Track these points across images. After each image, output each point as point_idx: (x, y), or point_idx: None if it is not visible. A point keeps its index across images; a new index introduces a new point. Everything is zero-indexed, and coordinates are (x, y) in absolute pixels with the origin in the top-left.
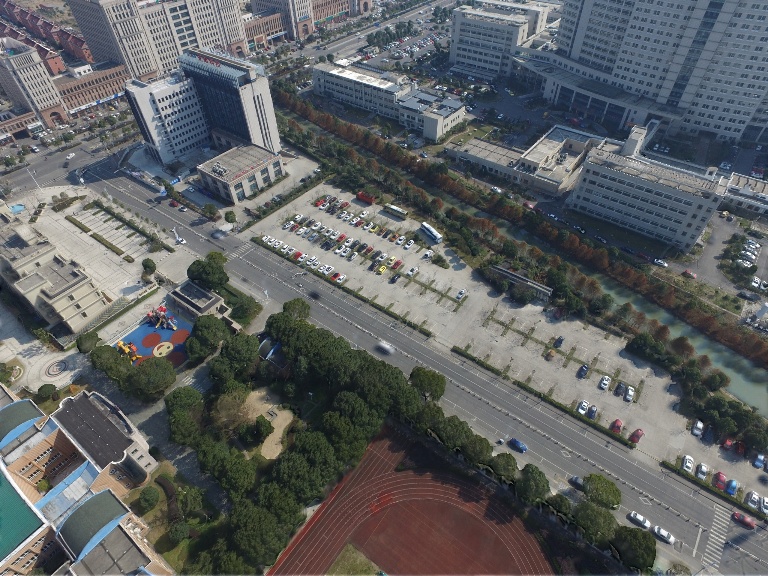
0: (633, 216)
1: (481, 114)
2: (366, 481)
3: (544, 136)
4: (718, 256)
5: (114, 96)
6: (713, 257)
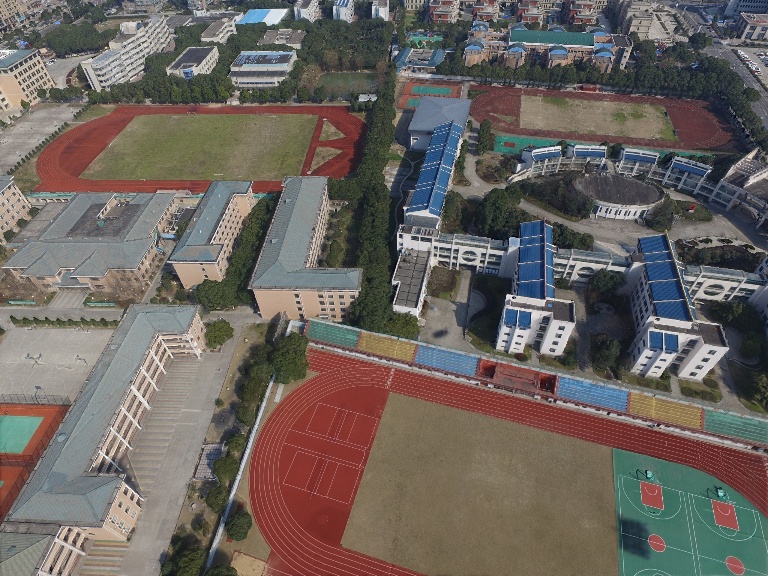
0: None
1: None
2: (687, 103)
3: None
4: None
5: None
6: None
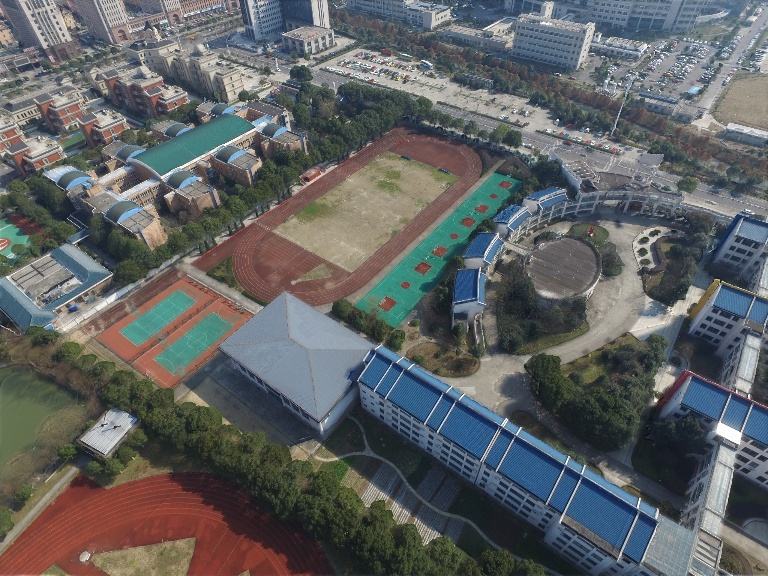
0: (545, 53)
1: (461, 17)
2: (394, 137)
3: (499, 21)
4: (592, 72)
5: (210, 8)
6: (588, 73)
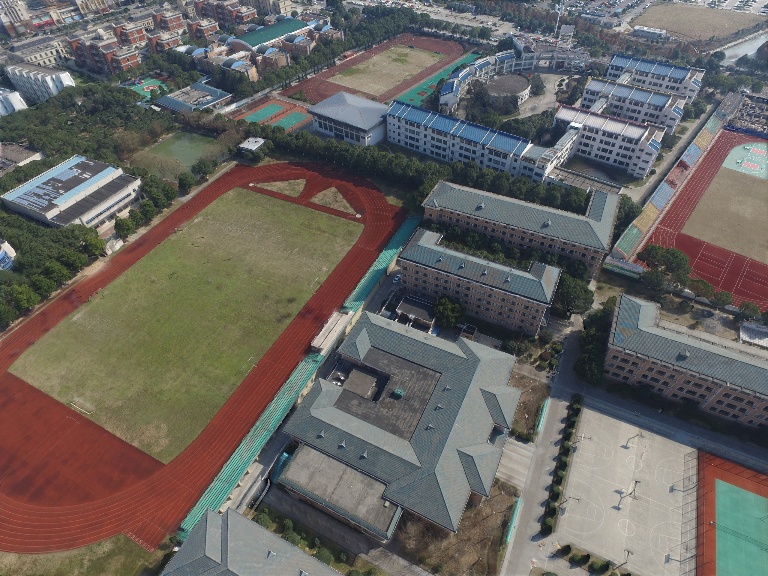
0: None
1: None
2: (403, 37)
3: None
4: (549, 3)
5: None
6: (547, 3)
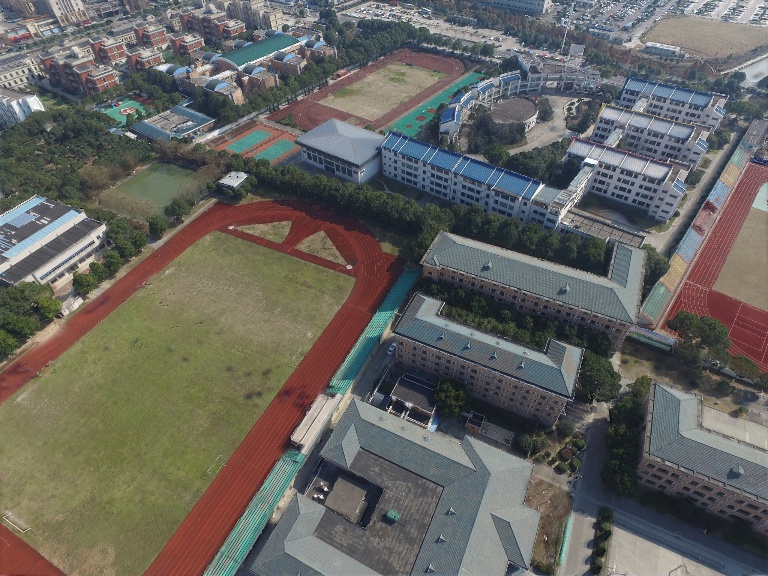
0: (519, 1)
1: None
2: None
3: None
4: (554, 15)
5: None
6: (552, 16)
